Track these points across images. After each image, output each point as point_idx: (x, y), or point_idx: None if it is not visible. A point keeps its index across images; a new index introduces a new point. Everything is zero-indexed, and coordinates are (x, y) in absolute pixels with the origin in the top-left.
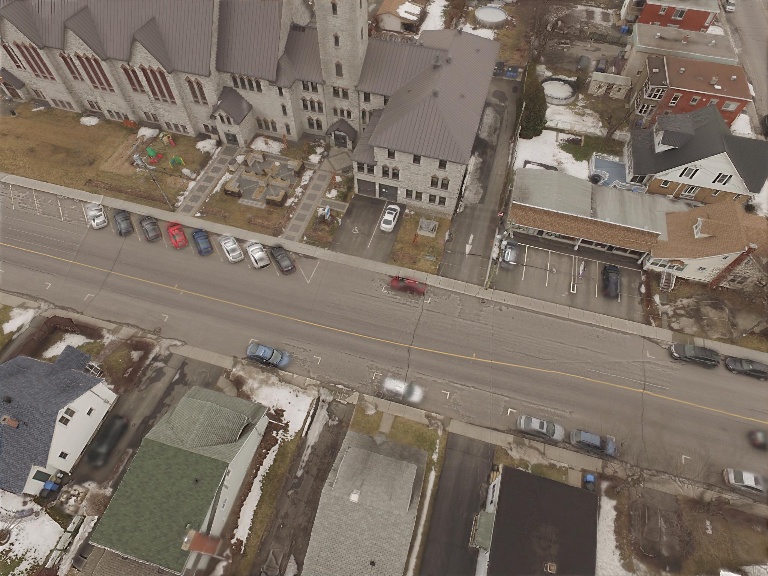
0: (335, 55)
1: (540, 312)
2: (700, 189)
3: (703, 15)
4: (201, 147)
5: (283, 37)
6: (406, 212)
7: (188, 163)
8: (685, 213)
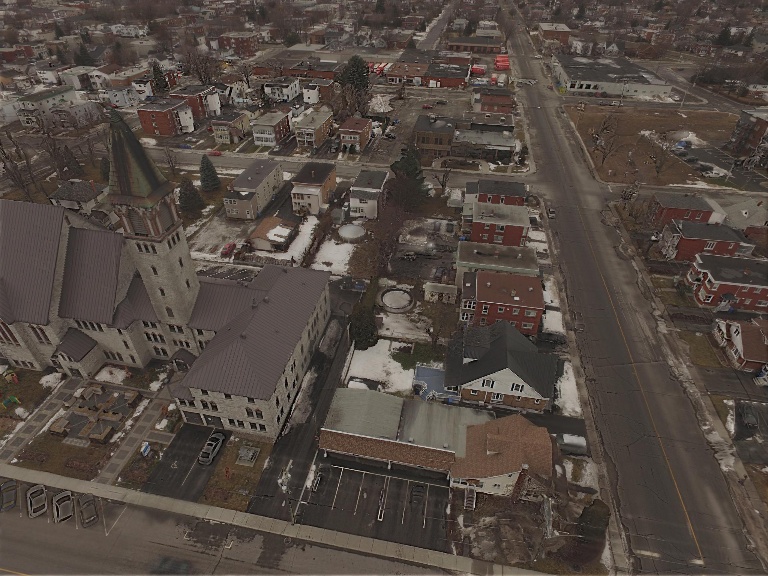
0: (164, 302)
1: (343, 548)
2: (504, 396)
3: (519, 229)
4: (44, 382)
5: (124, 286)
6: (231, 439)
7: (25, 401)
8: (482, 426)
